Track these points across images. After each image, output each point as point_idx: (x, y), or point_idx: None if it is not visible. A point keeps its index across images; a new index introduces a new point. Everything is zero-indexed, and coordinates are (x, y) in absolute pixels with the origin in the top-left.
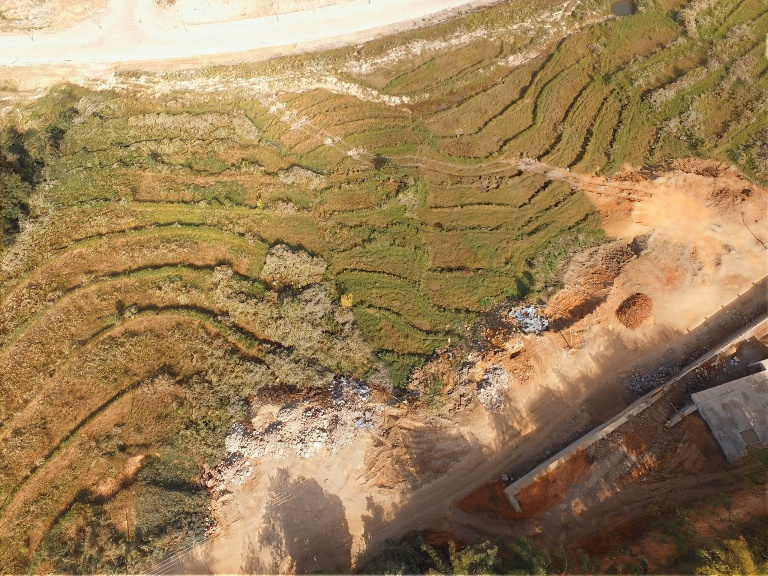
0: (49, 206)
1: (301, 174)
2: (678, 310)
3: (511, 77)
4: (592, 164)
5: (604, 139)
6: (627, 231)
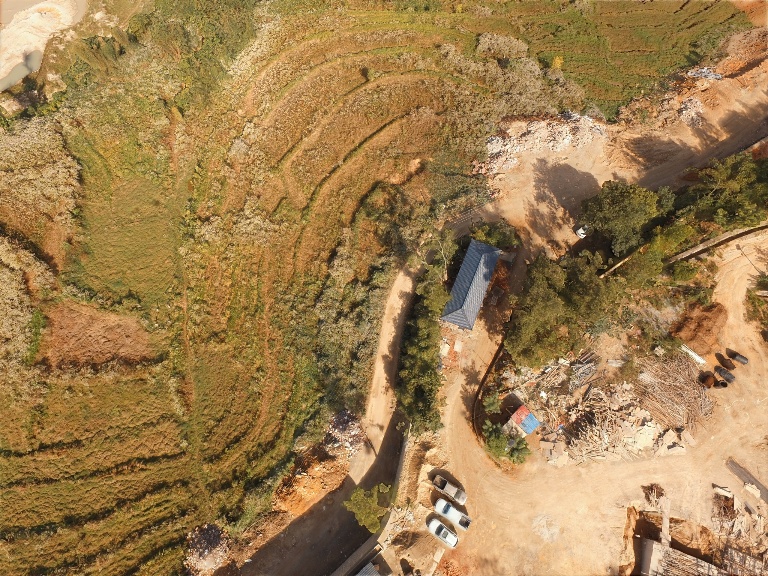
0: (273, 16)
1: None
2: None
3: None
4: None
5: None
6: None
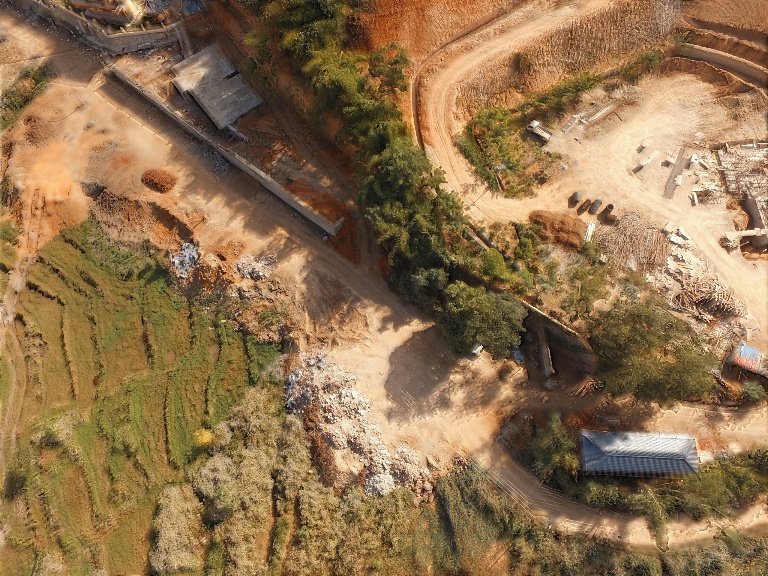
0: None
1: None
2: (151, 152)
3: None
4: (2, 251)
5: None
6: (79, 203)
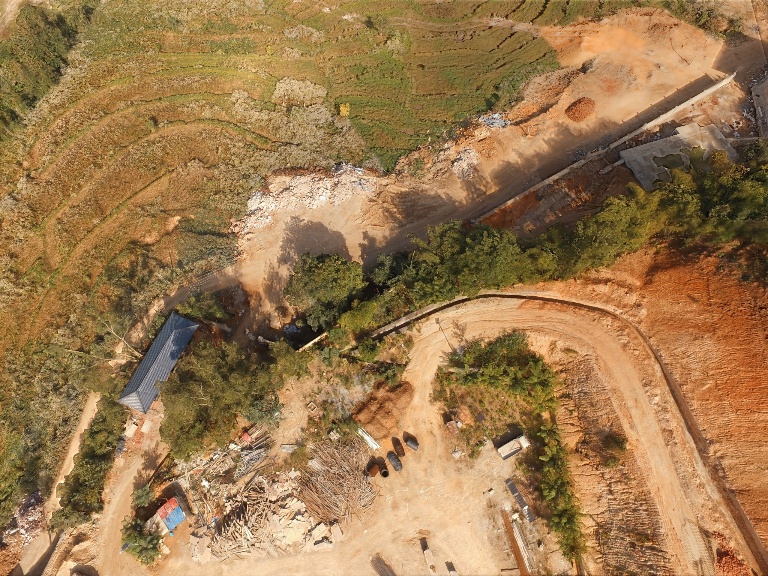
0: None
1: (303, 29)
2: (615, 108)
3: None
4: (551, 18)
5: None
6: (577, 59)
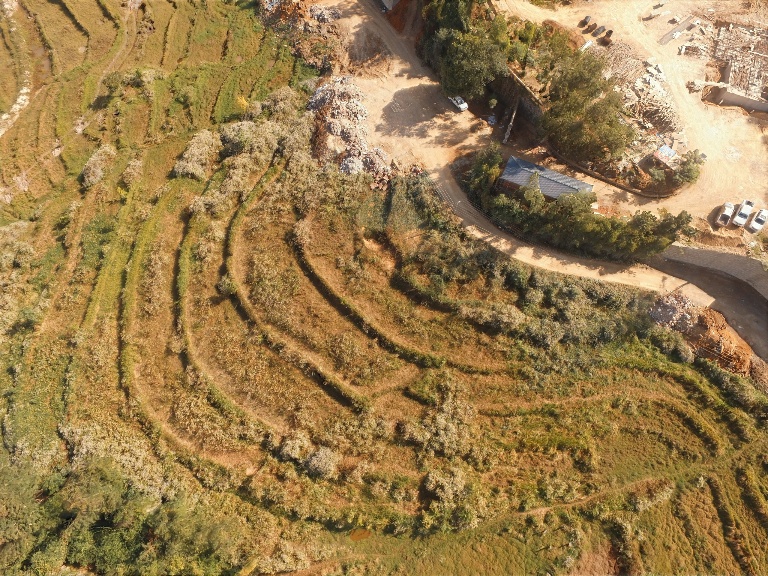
0: (57, 442)
1: (95, 160)
2: None
3: (31, 8)
4: None
5: None
6: None
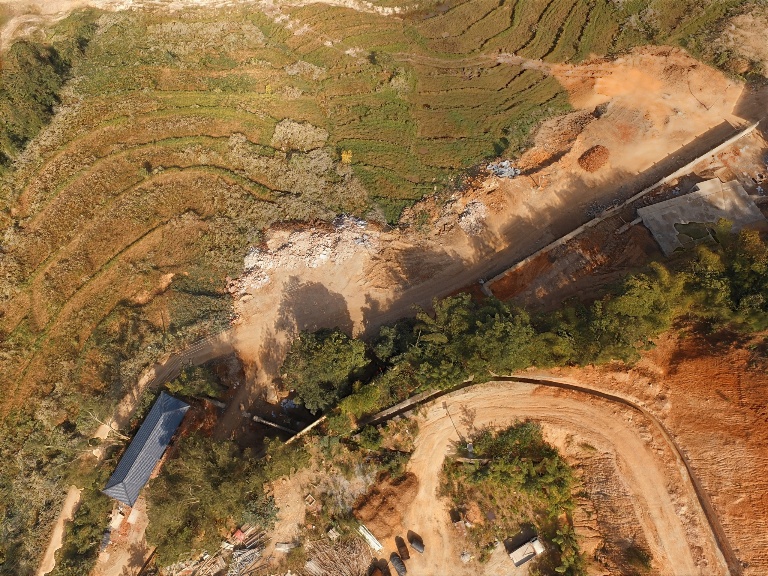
0: (79, 96)
1: (304, 65)
2: (631, 157)
3: None
4: (562, 55)
5: (573, 35)
6: (590, 102)
